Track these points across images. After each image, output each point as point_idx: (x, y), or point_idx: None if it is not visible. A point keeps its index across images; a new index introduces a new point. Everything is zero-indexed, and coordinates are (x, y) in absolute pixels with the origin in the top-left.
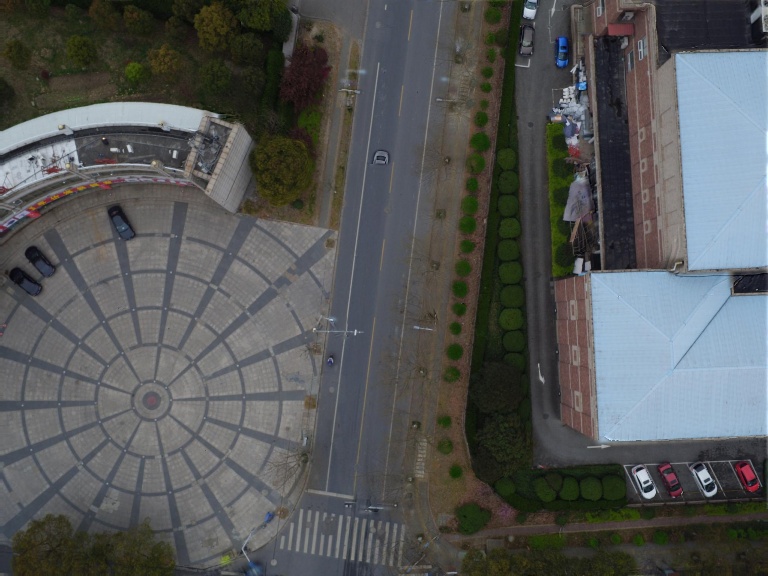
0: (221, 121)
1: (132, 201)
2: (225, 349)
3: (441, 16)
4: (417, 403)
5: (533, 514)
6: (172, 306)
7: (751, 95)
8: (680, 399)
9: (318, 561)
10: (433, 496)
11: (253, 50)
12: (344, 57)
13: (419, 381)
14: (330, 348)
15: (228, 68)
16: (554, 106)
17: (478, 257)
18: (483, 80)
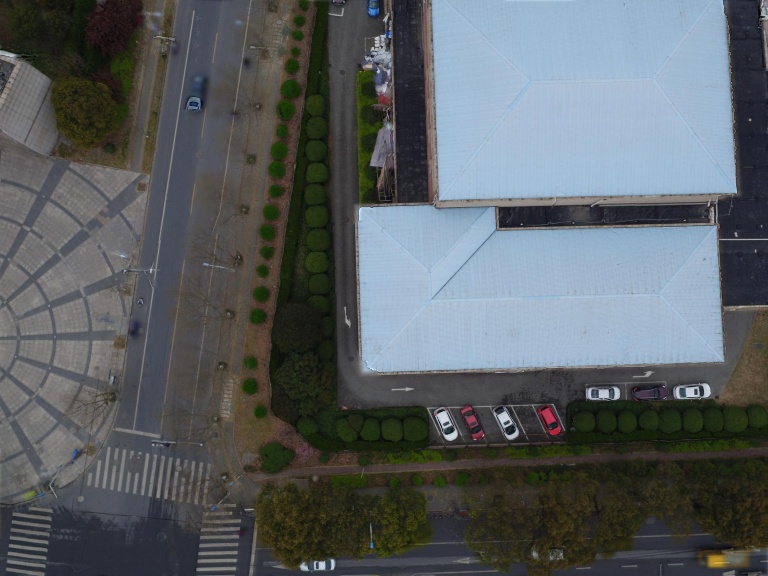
0: (7, 58)
1: None
2: (37, 289)
3: None
4: (224, 344)
5: (336, 455)
6: None
7: (501, 28)
8: (440, 330)
9: (124, 498)
10: (238, 436)
11: None
12: (160, 5)
13: (227, 323)
14: (140, 290)
15: (31, 11)
16: (366, 54)
17: (287, 202)
18: (296, 28)
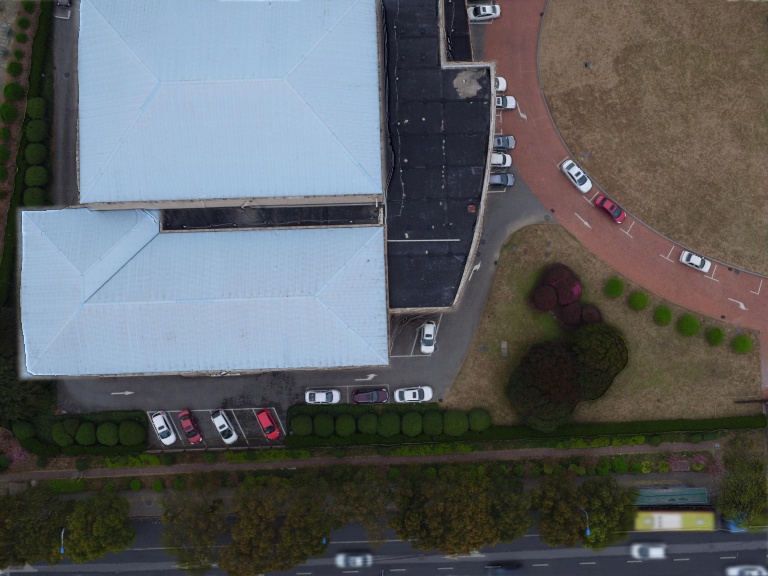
0: None
1: None
2: None
3: None
4: None
5: (55, 459)
6: None
7: (140, 29)
8: (95, 333)
9: None
10: None
11: None
12: None
13: None
14: None
15: None
16: None
17: None
18: (21, 31)
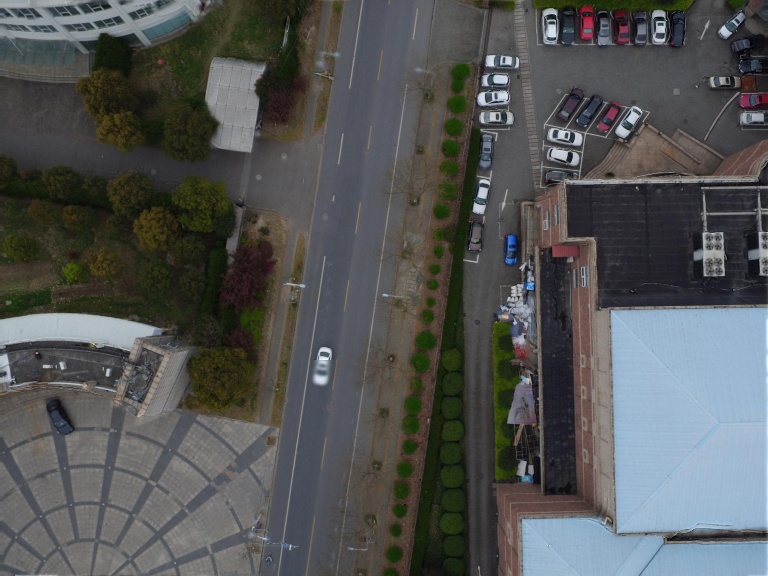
0: (153, 347)
1: (72, 394)
2: (163, 546)
3: (389, 209)
4: None
5: None
6: (110, 502)
7: (685, 359)
8: None
9: None
10: None
11: (194, 254)
12: (290, 250)
13: None
14: (269, 547)
15: (167, 275)
16: (502, 303)
17: (421, 457)
18: (430, 276)
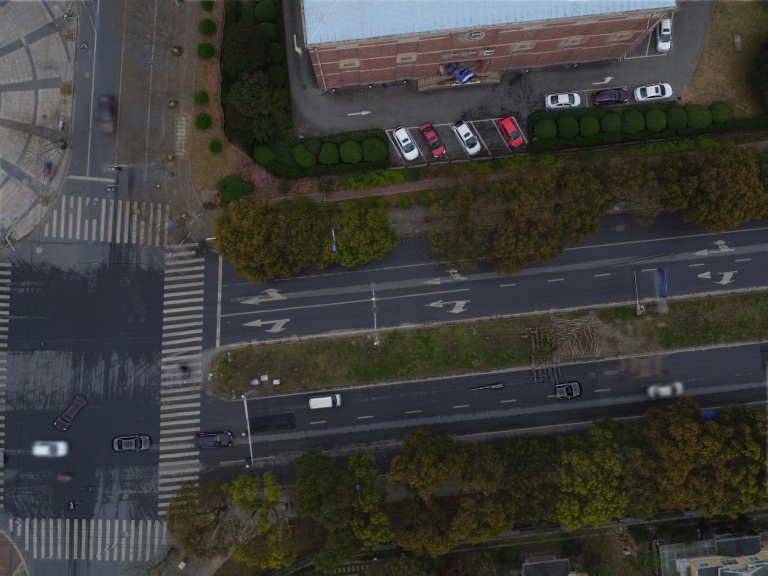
0: None
1: None
2: None
3: None
4: (173, 83)
5: (297, 185)
6: None
7: None
8: None
9: (83, 245)
10: (195, 173)
11: None
12: None
13: (174, 61)
14: (82, 34)
15: None
16: None
17: None
18: None
